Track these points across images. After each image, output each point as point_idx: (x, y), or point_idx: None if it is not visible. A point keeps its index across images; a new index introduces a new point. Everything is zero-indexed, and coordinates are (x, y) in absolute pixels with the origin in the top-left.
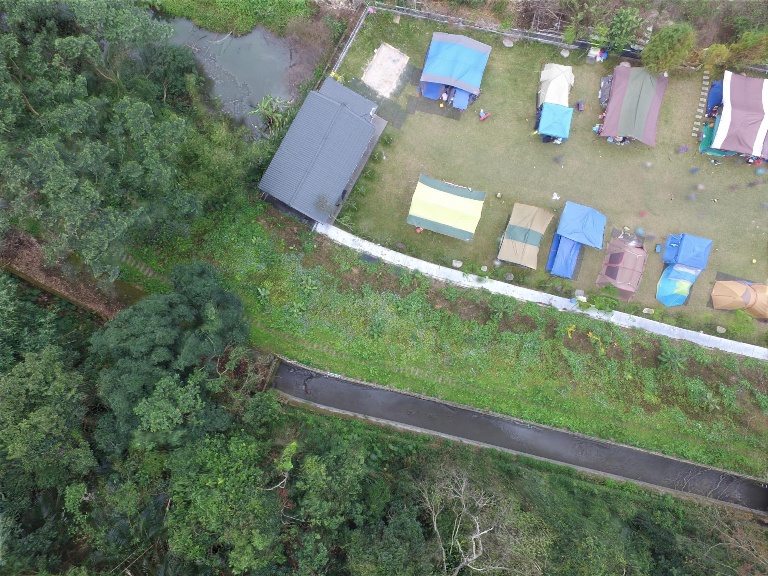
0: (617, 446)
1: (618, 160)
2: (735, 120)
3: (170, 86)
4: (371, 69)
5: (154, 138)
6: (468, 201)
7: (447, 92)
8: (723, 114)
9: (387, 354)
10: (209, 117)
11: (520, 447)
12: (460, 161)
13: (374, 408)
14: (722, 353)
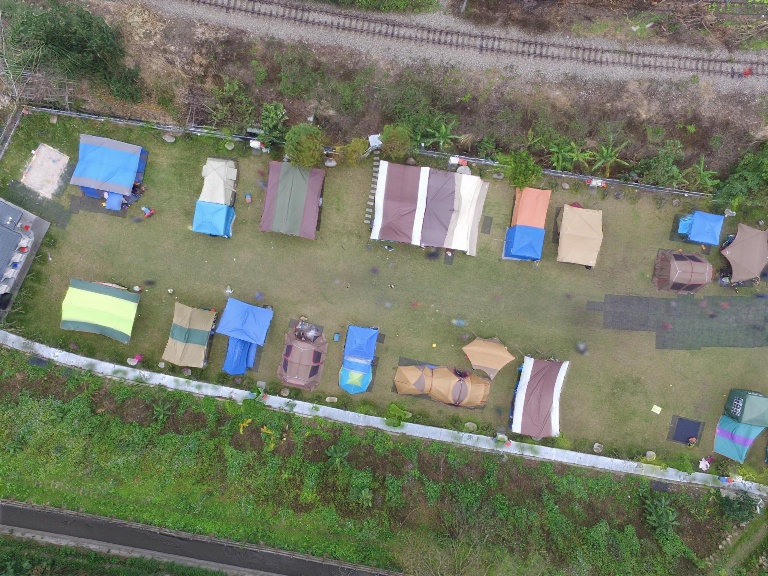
0: None
1: (291, 250)
2: (387, 212)
3: None
4: (32, 170)
5: None
6: (126, 303)
7: None
8: (376, 206)
9: (24, 469)
10: None
11: (180, 551)
12: (129, 259)
13: (28, 519)
14: (408, 438)
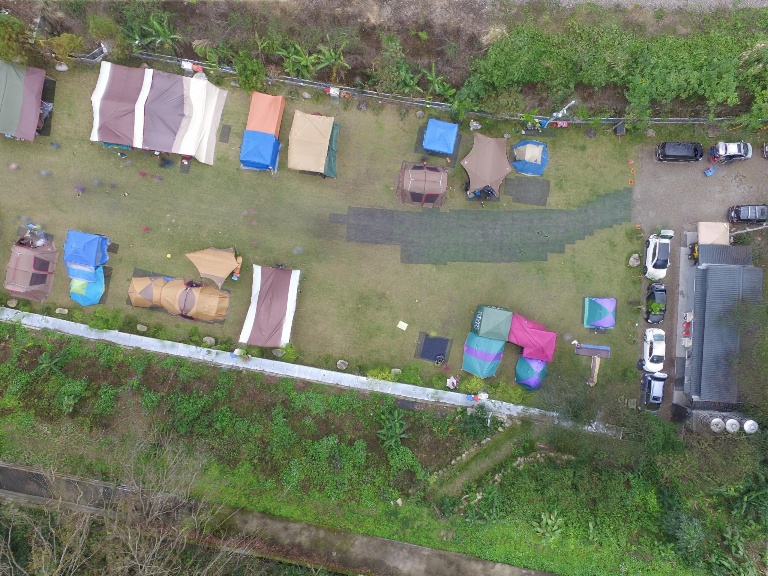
0: None
1: (19, 156)
2: (104, 111)
3: None
4: None
5: None
6: None
7: None
8: (93, 105)
9: None
10: None
11: None
12: None
13: None
14: (141, 352)
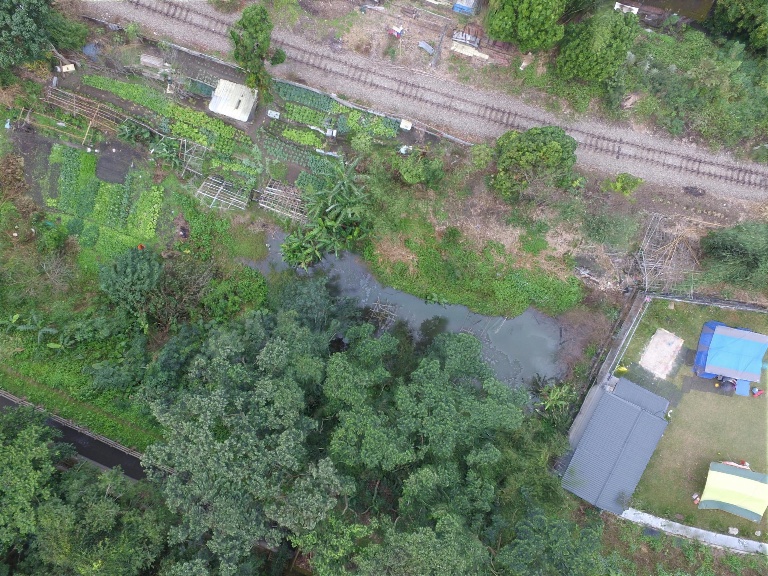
0: None
1: None
2: None
3: None
4: (647, 352)
5: (581, 561)
6: (753, 483)
7: None
8: None
9: None
10: None
11: None
12: (734, 434)
13: None
14: None
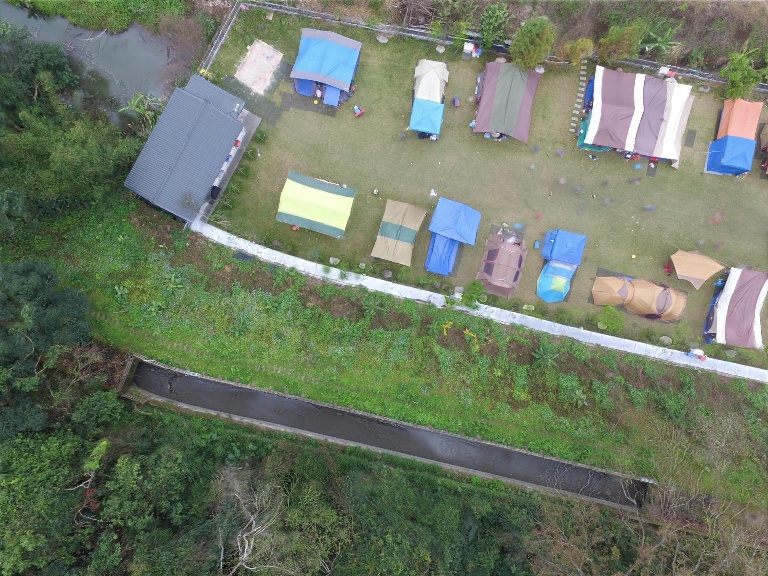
0: (480, 443)
1: (496, 156)
2: (605, 115)
3: (42, 84)
4: (245, 66)
5: None
6: (339, 198)
7: (320, 89)
8: (593, 109)
9: (249, 352)
10: (85, 115)
11: (390, 445)
12: (336, 158)
13: (241, 407)
14: (603, 349)
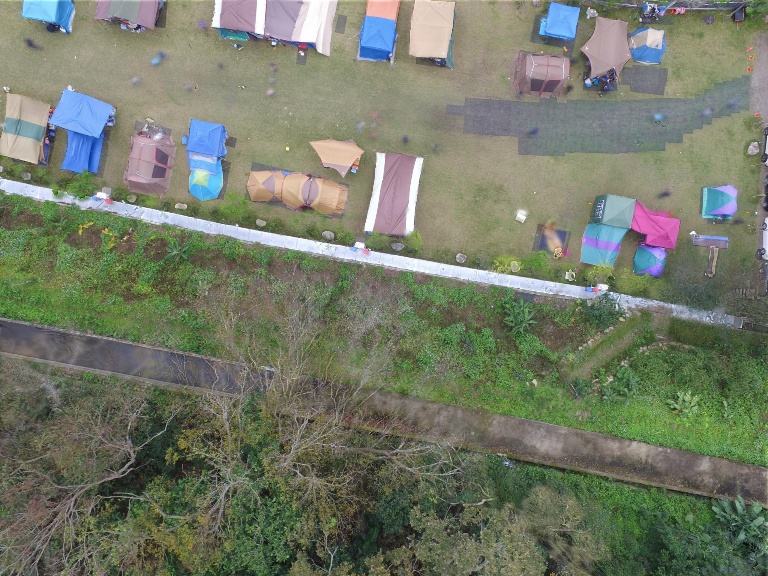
0: None
1: (135, 48)
2: None
3: None
4: None
5: None
6: None
7: None
8: None
9: None
10: None
11: (8, 348)
12: None
13: None
14: (262, 247)
